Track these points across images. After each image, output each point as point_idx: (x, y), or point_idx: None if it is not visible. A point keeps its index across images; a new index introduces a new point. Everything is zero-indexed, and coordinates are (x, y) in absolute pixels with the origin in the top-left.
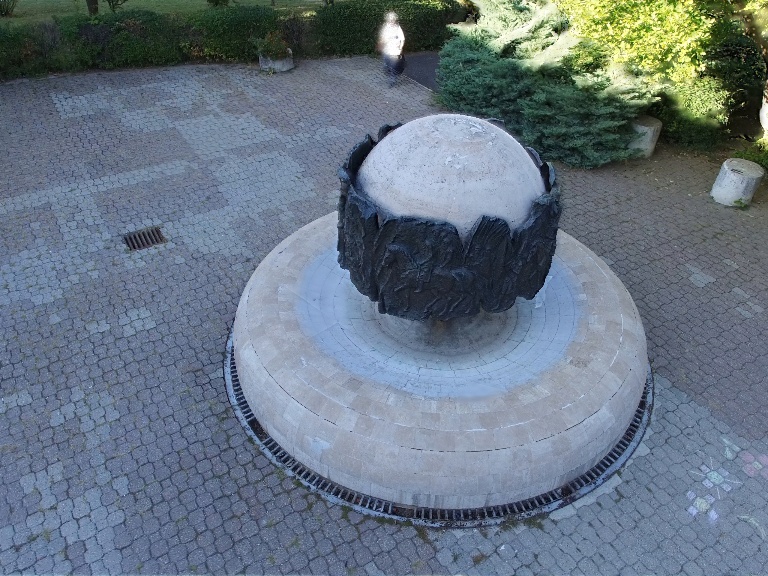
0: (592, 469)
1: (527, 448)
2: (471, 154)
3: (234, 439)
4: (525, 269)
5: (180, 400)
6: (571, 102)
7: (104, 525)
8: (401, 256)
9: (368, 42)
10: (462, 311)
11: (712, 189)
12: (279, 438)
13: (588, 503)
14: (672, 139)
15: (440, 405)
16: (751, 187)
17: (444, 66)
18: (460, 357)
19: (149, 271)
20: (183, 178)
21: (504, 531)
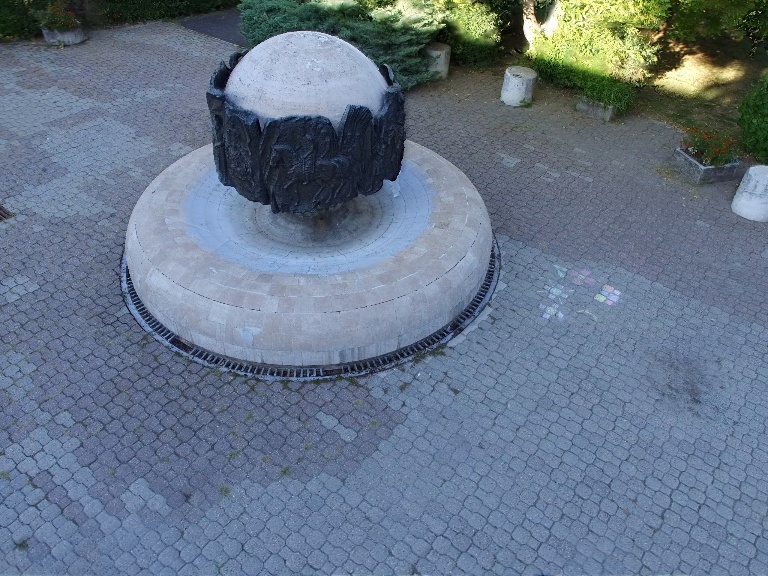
0: (469, 307)
1: (421, 292)
2: (326, 58)
3: (162, 357)
4: (387, 152)
5: (94, 340)
6: (374, 35)
7: (62, 453)
8: (286, 153)
9: (159, 6)
10: (344, 196)
11: (501, 95)
12: (207, 342)
13: (473, 330)
14: (460, 61)
15: (344, 276)
16: (530, 87)
17: (248, 18)
18: (345, 245)
19: (8, 243)
20: (7, 156)
21: (417, 364)
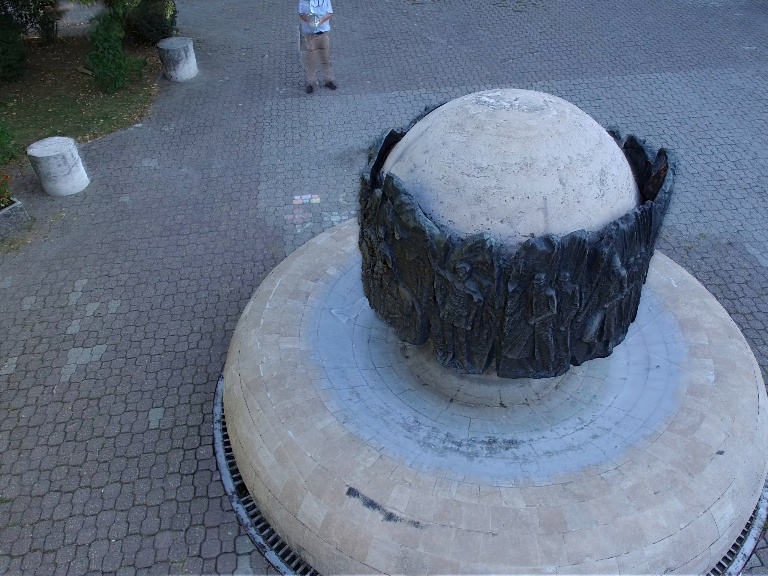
0: None
1: None
2: None
3: None
4: None
5: None
6: None
7: None
8: None
9: None
10: None
11: None
12: None
13: None
14: None
15: None
16: None
17: None
18: None
19: None
20: None
21: None
